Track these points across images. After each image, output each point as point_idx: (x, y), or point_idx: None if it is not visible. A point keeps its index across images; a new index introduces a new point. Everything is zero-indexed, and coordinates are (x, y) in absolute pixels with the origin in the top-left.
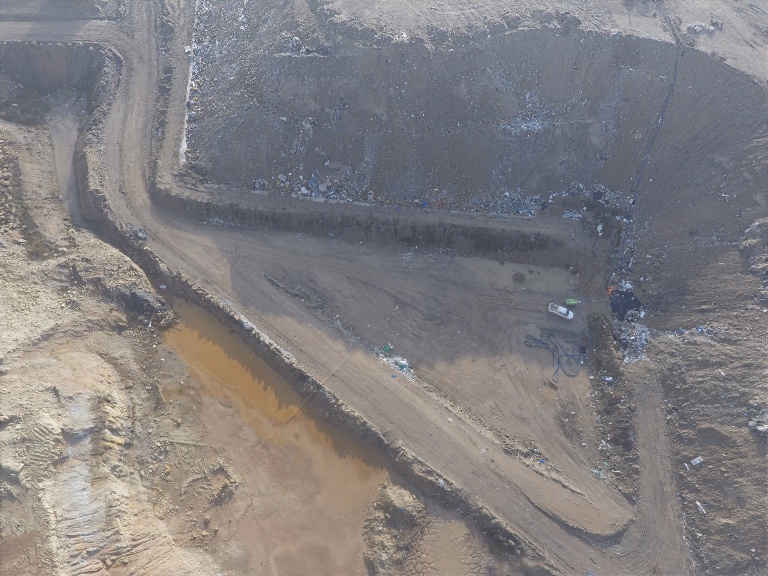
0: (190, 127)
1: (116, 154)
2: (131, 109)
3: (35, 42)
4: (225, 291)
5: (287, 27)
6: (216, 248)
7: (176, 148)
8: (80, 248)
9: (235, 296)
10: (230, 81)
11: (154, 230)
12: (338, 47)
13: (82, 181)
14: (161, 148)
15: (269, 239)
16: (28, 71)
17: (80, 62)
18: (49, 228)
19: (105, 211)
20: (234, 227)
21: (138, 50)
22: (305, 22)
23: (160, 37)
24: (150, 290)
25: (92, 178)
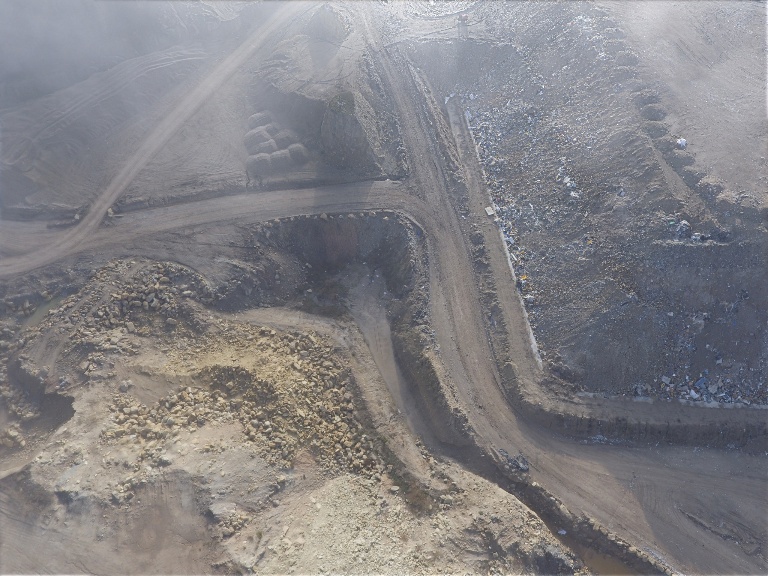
0: (532, 315)
1: (456, 355)
2: (451, 293)
3: (326, 216)
4: (647, 539)
5: (664, 206)
6: (612, 477)
7: (527, 345)
8: (467, 494)
9: (661, 545)
10: (580, 262)
11: (533, 457)
12: (738, 232)
13: (433, 397)
14: (508, 345)
15: (665, 458)
16: (315, 247)
17: (373, 234)
18: (415, 464)
19: (471, 435)
20: (621, 445)
21: (435, 215)
22: (688, 201)
23: (455, 198)
24: (556, 542)
25: (446, 393)
